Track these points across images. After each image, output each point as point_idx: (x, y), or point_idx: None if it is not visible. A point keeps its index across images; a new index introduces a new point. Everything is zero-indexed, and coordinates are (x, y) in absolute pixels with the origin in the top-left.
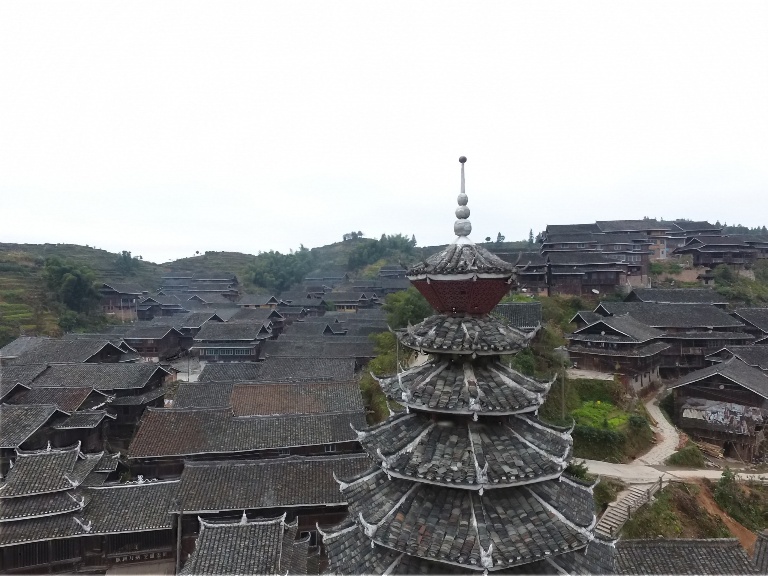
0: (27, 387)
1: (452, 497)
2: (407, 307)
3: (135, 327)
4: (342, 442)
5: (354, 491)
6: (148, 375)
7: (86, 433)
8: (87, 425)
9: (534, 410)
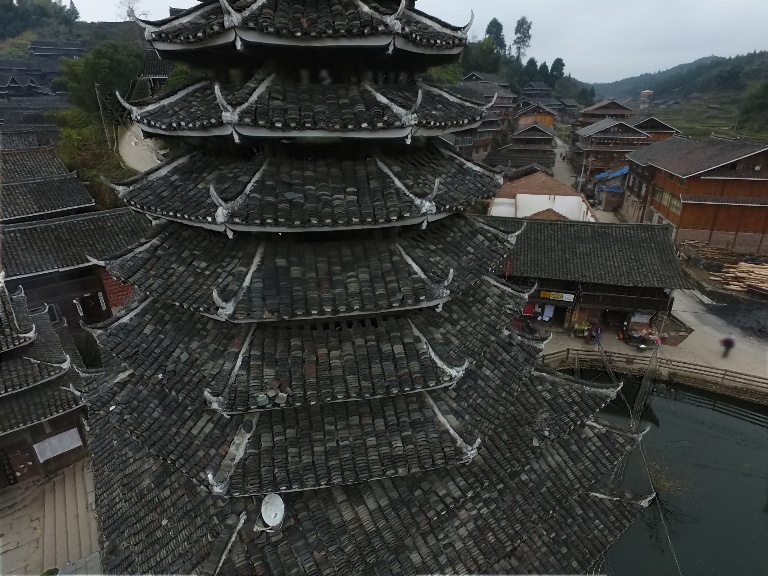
0: None
1: (325, 1)
2: (99, 61)
3: None
4: (55, 211)
5: None
6: None
7: None
8: None
9: None
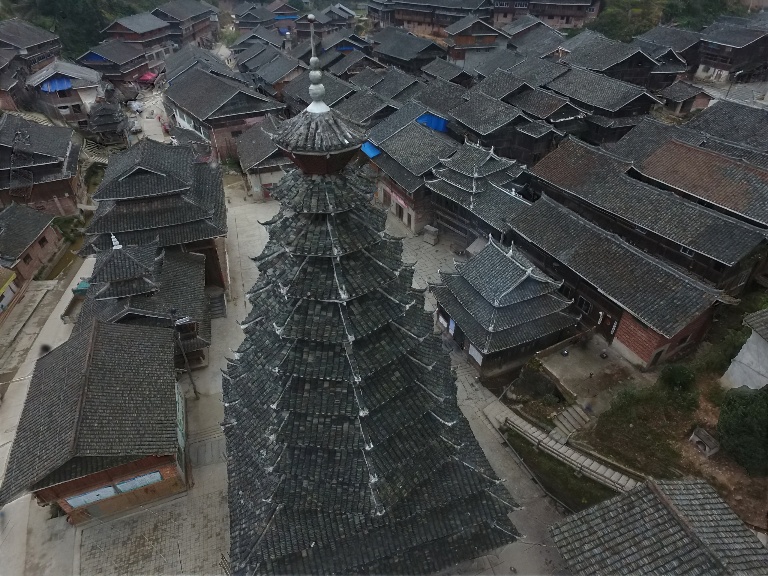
0: (532, 87)
1: None
2: None
3: (725, 26)
4: (697, 251)
5: None
6: (627, 100)
7: (533, 140)
8: (533, 134)
9: (289, 253)
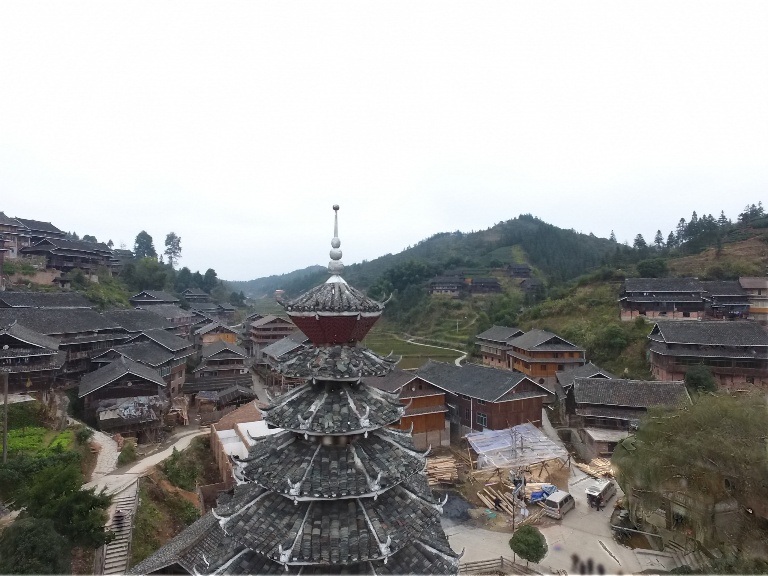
0: None
1: None
2: None
3: None
4: None
5: (306, 548)
6: None
7: None
8: None
9: None
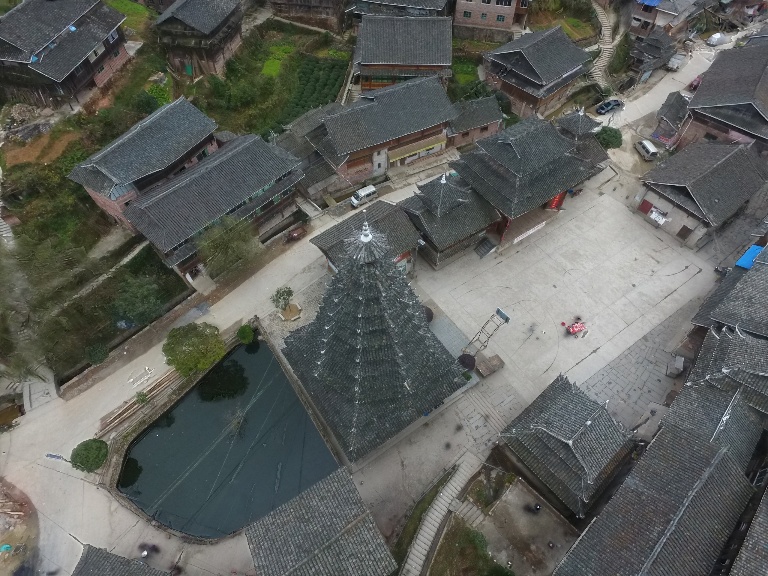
0: None
1: None
2: None
3: None
4: None
5: None
6: None
7: None
8: None
9: None
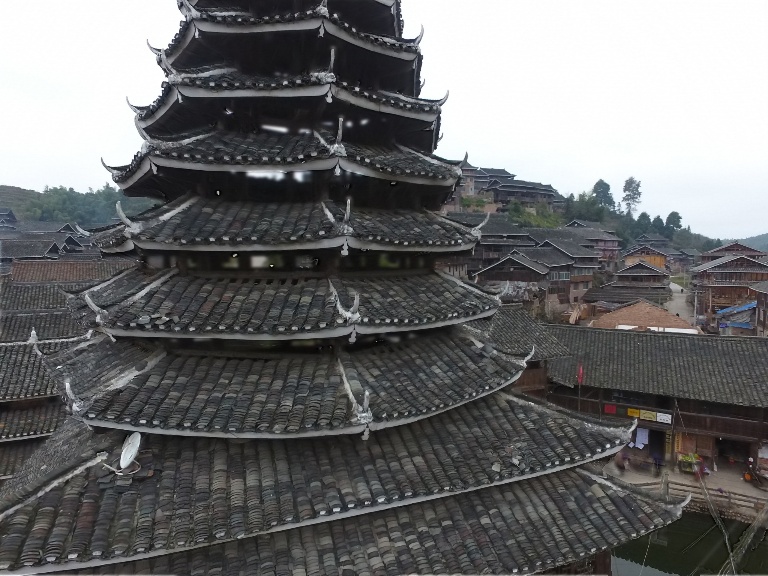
0: None
1: None
2: None
3: None
4: None
5: None
6: None
7: None
8: None
9: None
